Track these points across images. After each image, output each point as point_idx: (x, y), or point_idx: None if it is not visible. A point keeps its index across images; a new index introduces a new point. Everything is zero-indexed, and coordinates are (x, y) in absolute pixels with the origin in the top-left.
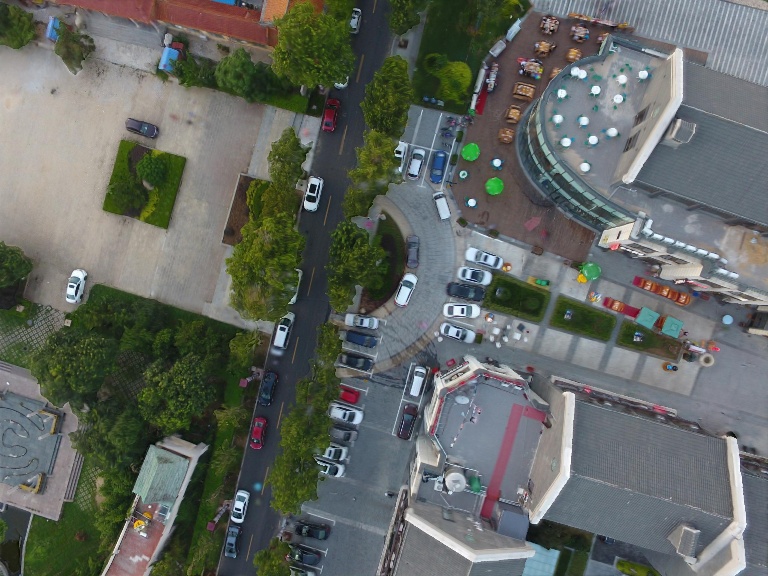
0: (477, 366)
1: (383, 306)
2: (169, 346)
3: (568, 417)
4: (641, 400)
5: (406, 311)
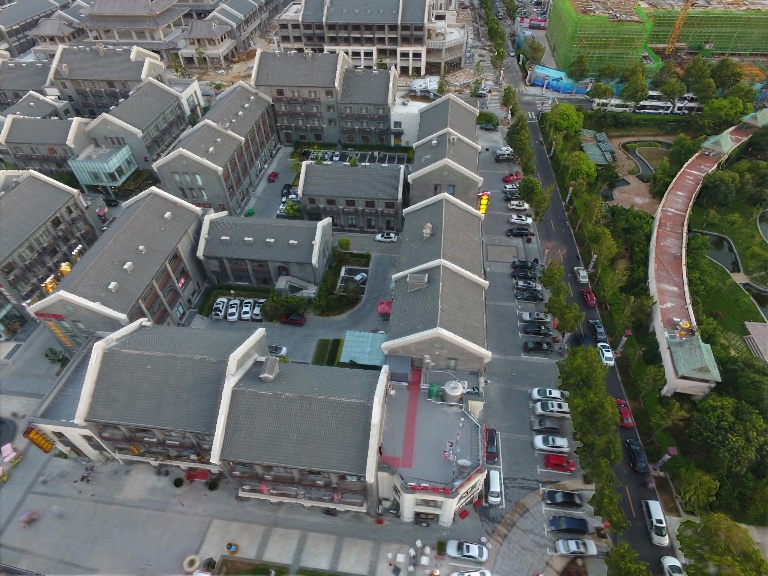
0: (454, 503)
1: (559, 573)
2: (767, 480)
3: (374, 454)
4: (274, 500)
5: (531, 570)
